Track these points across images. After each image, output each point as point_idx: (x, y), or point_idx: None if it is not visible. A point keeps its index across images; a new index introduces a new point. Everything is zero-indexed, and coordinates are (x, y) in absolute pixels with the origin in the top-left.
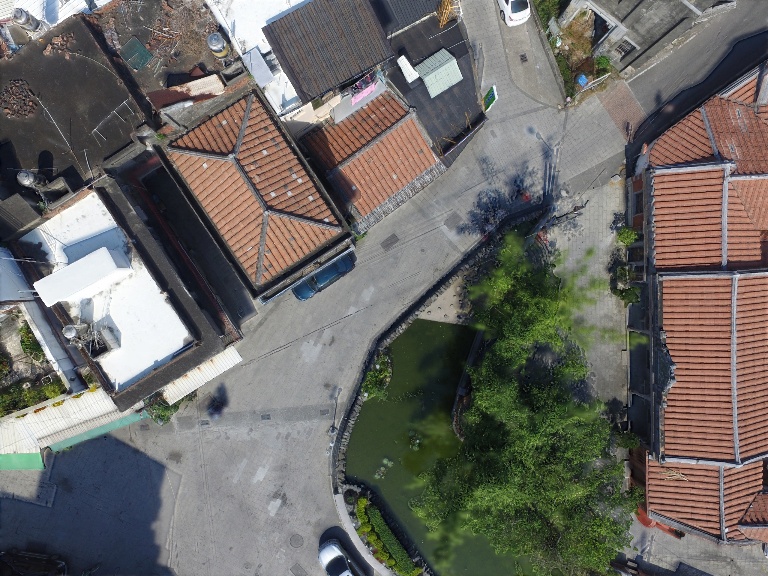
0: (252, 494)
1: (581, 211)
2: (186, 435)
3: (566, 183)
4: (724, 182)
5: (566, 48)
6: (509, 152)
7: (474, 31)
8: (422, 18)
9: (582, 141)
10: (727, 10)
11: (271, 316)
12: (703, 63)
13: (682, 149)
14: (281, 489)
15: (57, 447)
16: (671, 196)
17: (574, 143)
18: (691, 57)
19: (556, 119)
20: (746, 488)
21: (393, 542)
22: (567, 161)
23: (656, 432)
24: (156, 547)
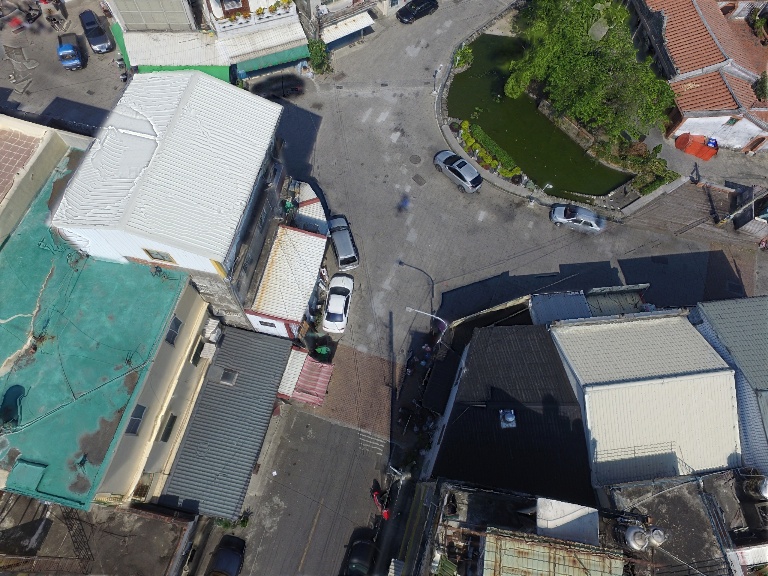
0: (377, 129)
1: None
2: (325, 94)
3: None
4: None
5: None
6: None
7: None
8: None
9: None
10: None
11: (384, 33)
12: None
13: None
14: (399, 126)
15: (242, 67)
16: None
17: None
18: None
19: None
20: None
21: (494, 144)
22: None
23: (667, 63)
24: (301, 163)
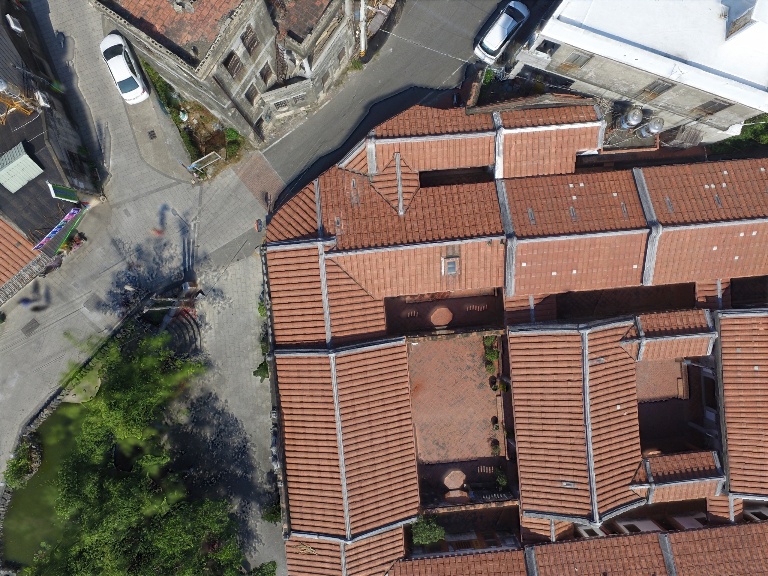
0: None
1: (228, 284)
2: None
3: (207, 257)
4: (319, 260)
5: (194, 122)
6: (145, 230)
7: (98, 110)
8: (11, 109)
9: (220, 214)
10: (307, 87)
11: None
12: (339, 128)
13: (294, 224)
14: None
15: None
16: (282, 273)
17: (211, 217)
18: (327, 123)
19: (191, 194)
20: (380, 557)
21: None
22: (206, 235)
23: None
24: None
